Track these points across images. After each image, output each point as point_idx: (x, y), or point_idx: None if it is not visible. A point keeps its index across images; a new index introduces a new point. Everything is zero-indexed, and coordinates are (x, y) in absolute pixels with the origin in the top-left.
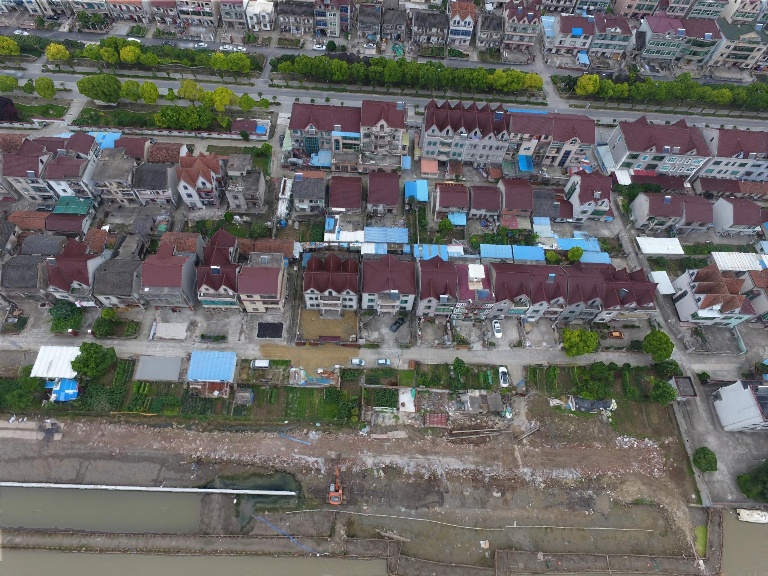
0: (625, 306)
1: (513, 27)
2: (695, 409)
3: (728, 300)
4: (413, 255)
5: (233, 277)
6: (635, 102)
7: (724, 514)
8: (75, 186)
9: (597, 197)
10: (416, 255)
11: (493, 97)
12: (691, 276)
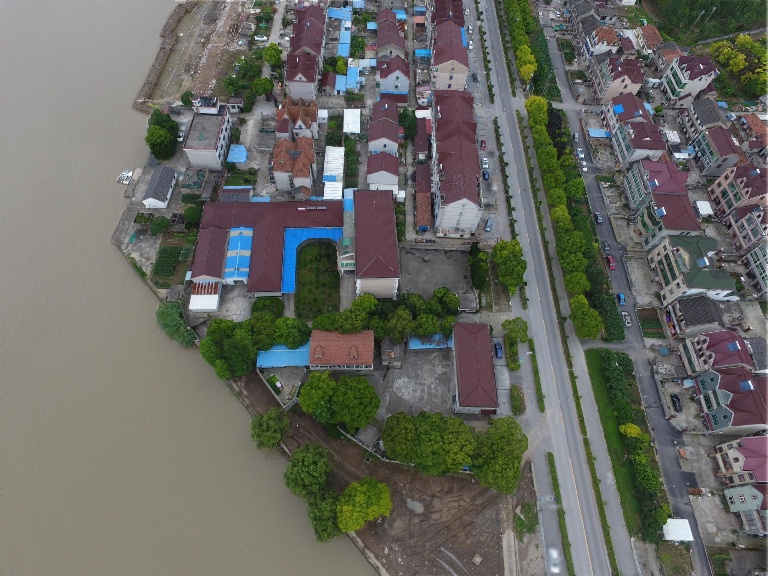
0: None
1: None
2: None
3: None
4: None
5: None
6: None
7: None
8: None
9: (383, 67)
10: None
11: None
12: None
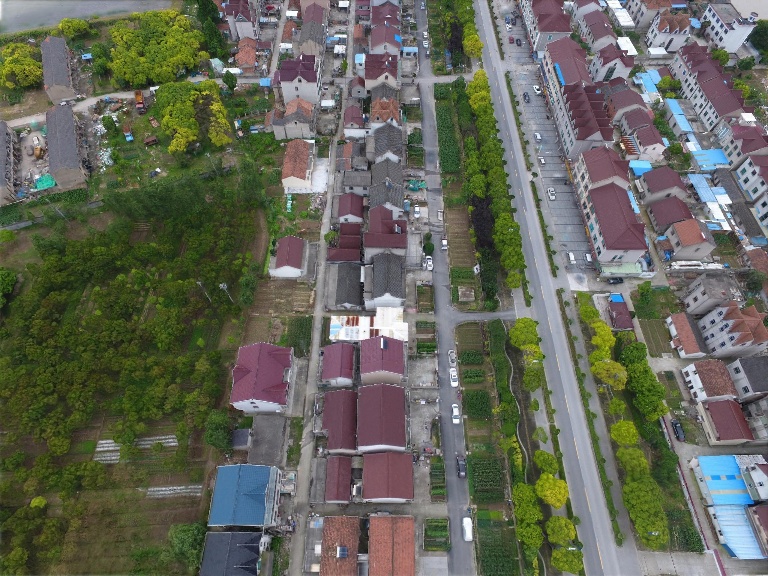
0: None
1: None
2: None
3: None
4: None
5: None
6: None
7: None
8: None
9: None
10: (714, 168)
11: None
12: (666, 32)
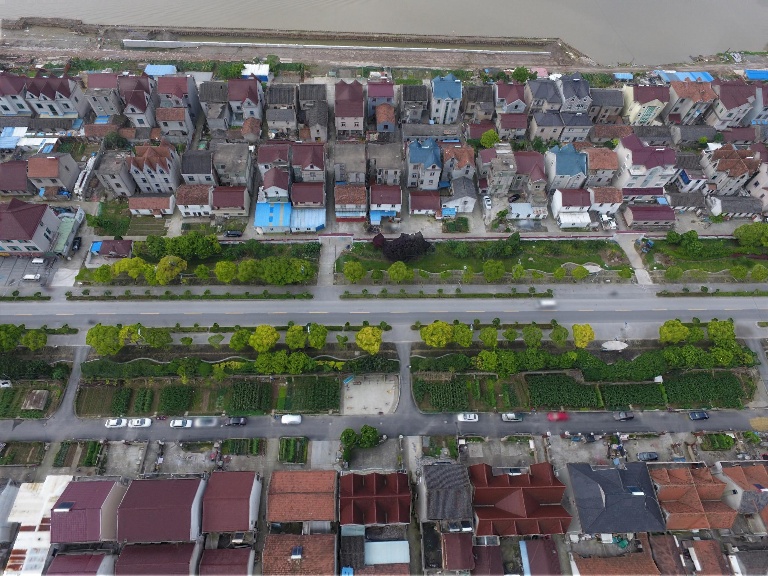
0: None
1: None
2: None
3: None
4: None
5: None
6: None
7: None
8: None
9: None
10: None
11: None
12: None
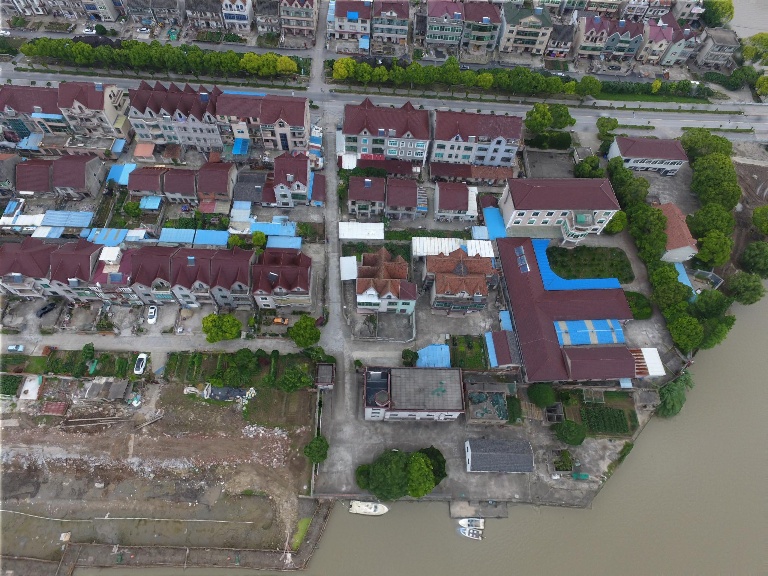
0: (277, 291)
1: (285, 11)
2: (341, 397)
3: (384, 285)
4: None
5: None
6: (402, 87)
7: (337, 506)
8: None
9: (290, 180)
10: (88, 239)
11: (248, 81)
12: None
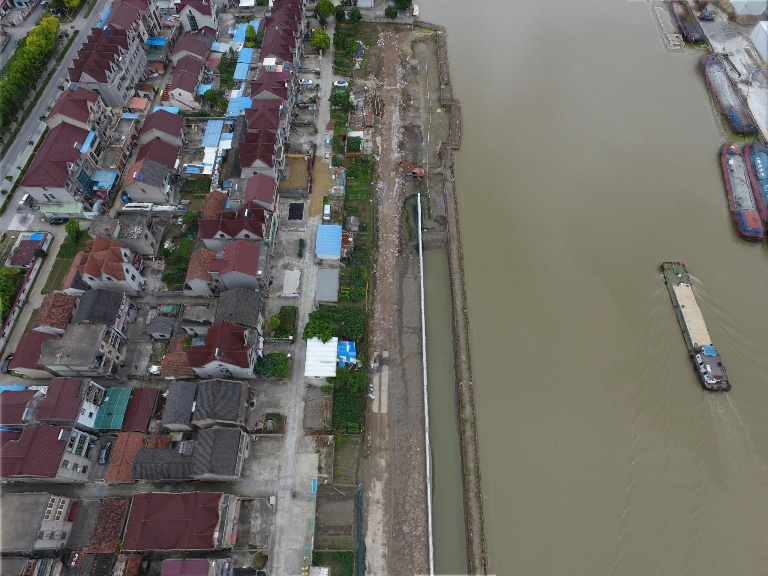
0: None
1: None
2: None
3: None
4: (236, 119)
5: (255, 206)
6: None
7: None
8: (90, 396)
9: (207, 4)
10: (238, 114)
11: (55, 59)
12: None
